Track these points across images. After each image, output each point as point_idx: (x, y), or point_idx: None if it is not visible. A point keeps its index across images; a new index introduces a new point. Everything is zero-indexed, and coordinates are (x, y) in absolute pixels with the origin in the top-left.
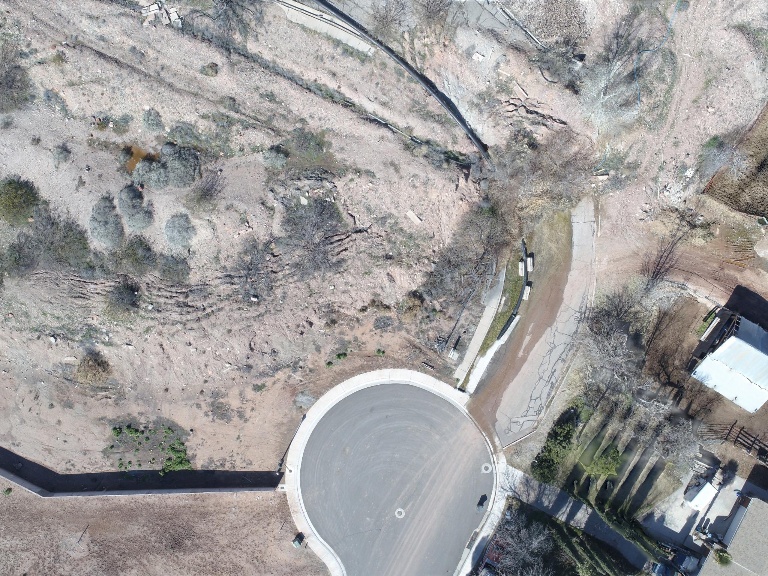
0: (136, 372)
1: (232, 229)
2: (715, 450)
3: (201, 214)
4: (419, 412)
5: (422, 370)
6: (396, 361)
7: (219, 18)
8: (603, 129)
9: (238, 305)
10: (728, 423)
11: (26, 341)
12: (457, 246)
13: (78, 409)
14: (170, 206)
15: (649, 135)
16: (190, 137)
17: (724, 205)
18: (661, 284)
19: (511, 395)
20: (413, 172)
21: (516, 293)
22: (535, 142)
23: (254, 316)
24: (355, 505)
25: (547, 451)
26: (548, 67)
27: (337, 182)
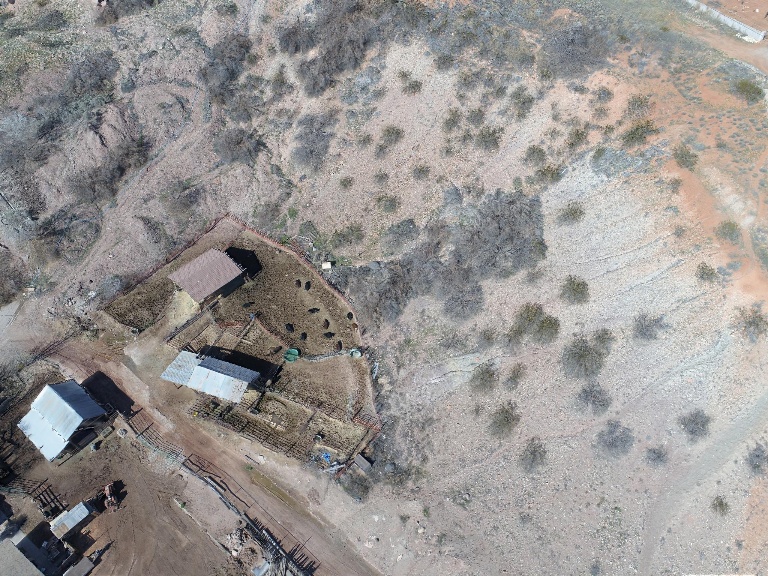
0: None
1: None
2: (15, 503)
3: None
4: None
5: None
6: None
7: None
8: (34, 256)
9: None
10: (39, 480)
11: None
12: None
13: None
14: None
15: (69, 267)
16: None
17: (112, 318)
18: (40, 362)
19: None
20: None
21: None
22: None
23: None
24: None
25: None
26: None
27: None
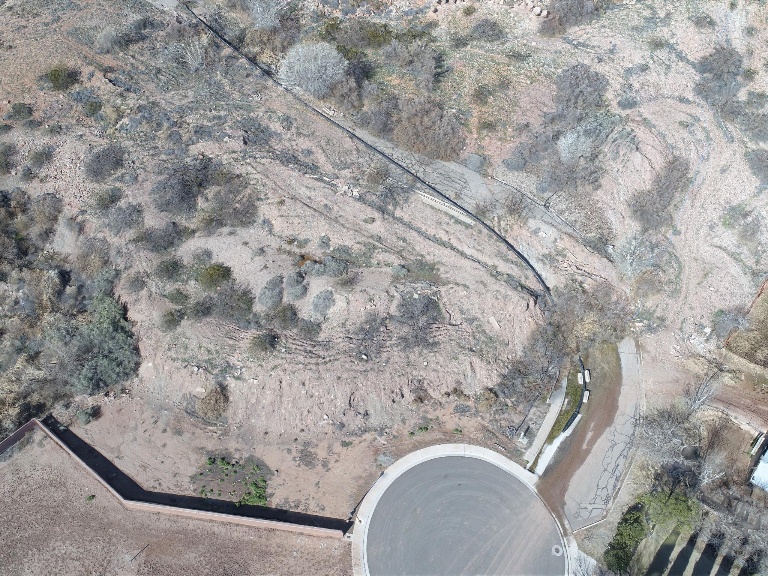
0: (247, 412)
1: (361, 304)
2: None
3: (342, 292)
4: (490, 485)
5: (494, 449)
6: (471, 439)
7: (382, 196)
8: (634, 288)
9: (351, 359)
10: None
11: (173, 370)
12: (526, 360)
13: (185, 437)
14: (321, 286)
15: (669, 300)
16: (346, 253)
17: (743, 358)
18: (703, 407)
19: (578, 482)
20: (496, 289)
21: (577, 397)
22: (584, 290)
23: (361, 370)
24: (419, 568)
25: (619, 534)
26: (590, 245)
27: (441, 288)
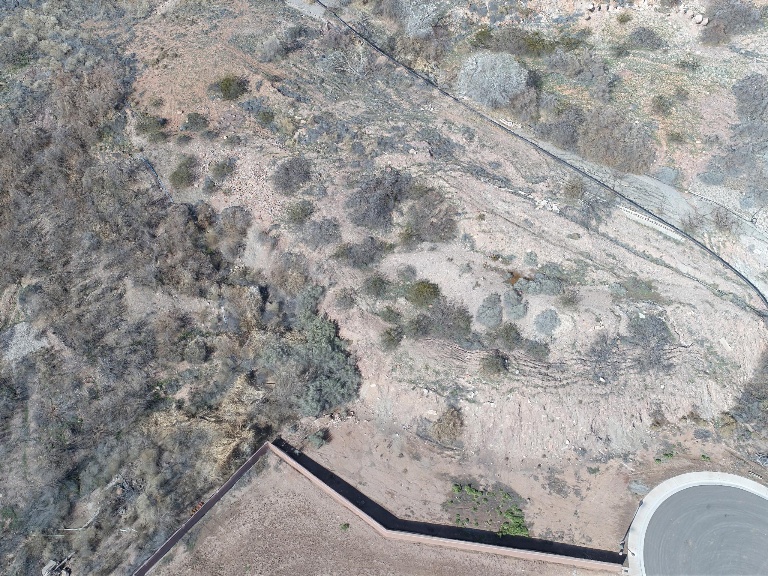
0: (483, 436)
1: (589, 324)
2: None
3: (566, 312)
4: (758, 516)
5: (751, 478)
6: (723, 467)
7: (584, 211)
8: None
9: (589, 382)
10: None
11: (400, 392)
12: (757, 383)
13: (424, 462)
14: (542, 305)
15: None
16: (556, 271)
17: None
18: None
19: None
20: (725, 309)
21: None
22: None
23: (601, 394)
24: None
25: None
26: None
27: (667, 308)
